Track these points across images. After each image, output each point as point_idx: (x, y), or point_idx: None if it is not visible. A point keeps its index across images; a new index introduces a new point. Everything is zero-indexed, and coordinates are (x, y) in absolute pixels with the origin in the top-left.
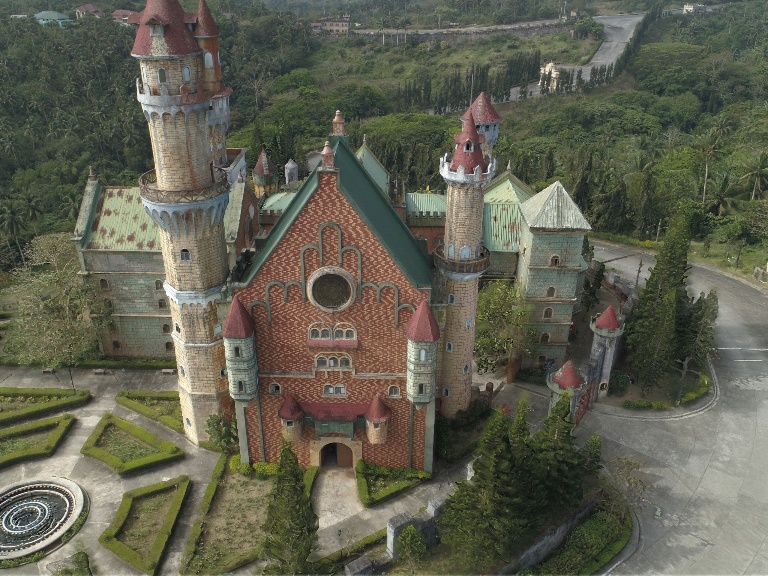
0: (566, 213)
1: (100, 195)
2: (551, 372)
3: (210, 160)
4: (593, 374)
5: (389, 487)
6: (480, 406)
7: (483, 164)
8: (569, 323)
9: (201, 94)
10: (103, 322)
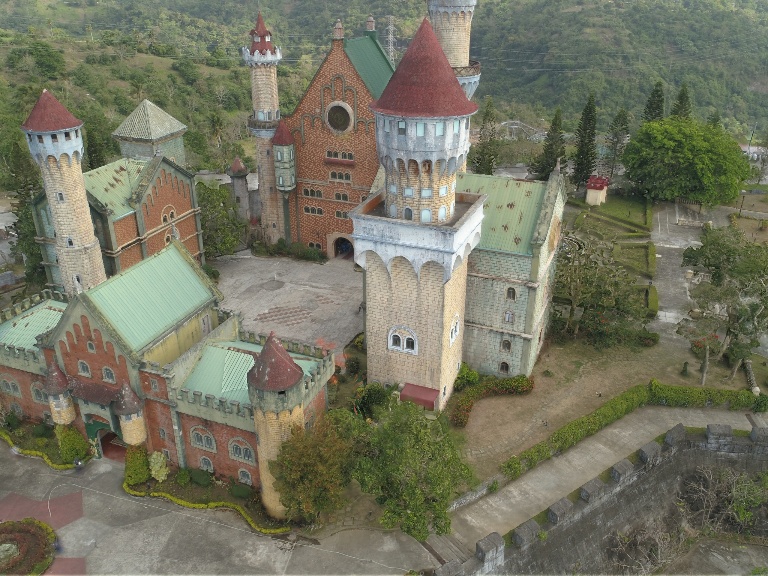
0: None
1: None
2: (241, 172)
3: None
4: None
5: None
6: None
7: None
8: None
9: None
10: None
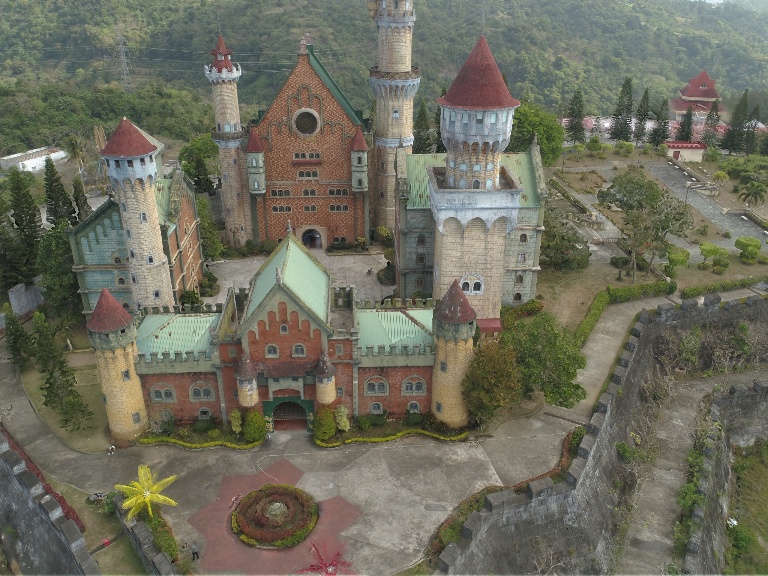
0: None
1: None
2: None
3: None
4: None
5: None
6: None
7: None
8: None
9: None
10: None
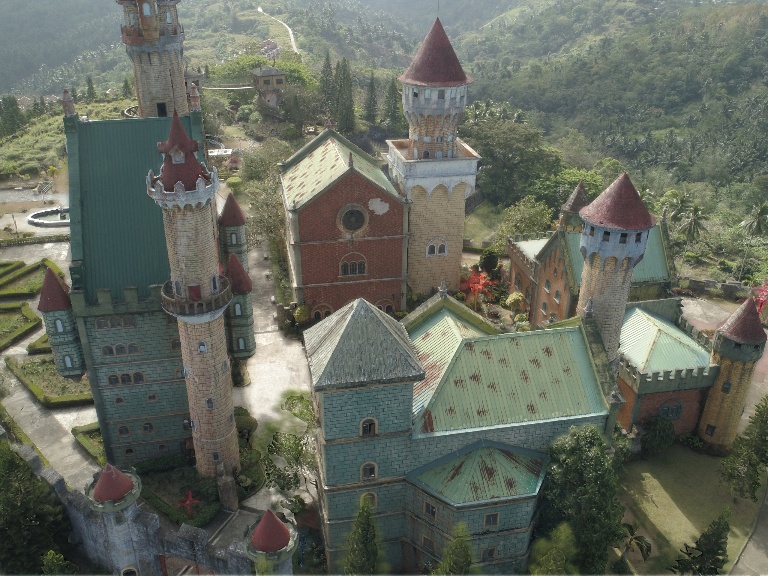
0: (326, 344)
1: (323, 141)
2: None
3: (159, 100)
4: (215, 563)
5: (96, 444)
6: (204, 484)
7: (172, 182)
8: (326, 517)
9: (136, 38)
10: (271, 236)
